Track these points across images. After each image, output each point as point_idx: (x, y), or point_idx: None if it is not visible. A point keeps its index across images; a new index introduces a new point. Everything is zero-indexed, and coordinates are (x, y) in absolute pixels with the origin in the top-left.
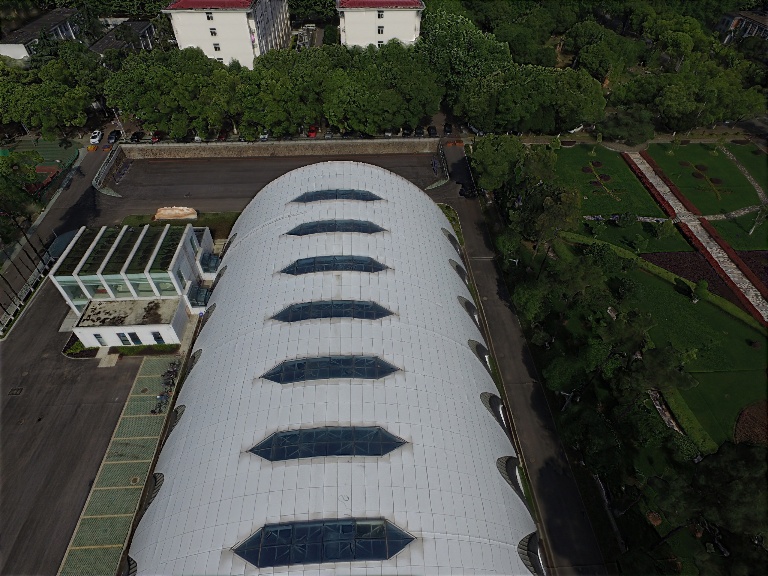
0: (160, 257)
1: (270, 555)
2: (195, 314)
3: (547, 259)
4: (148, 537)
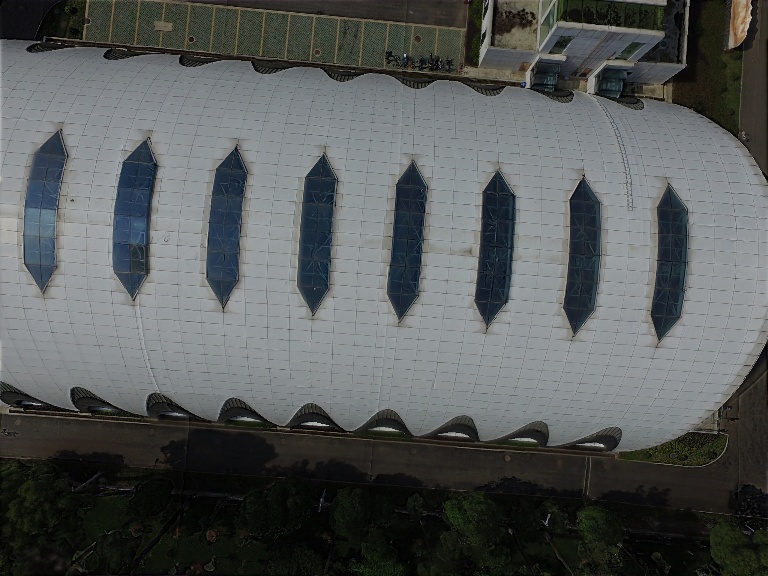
0: (591, 5)
1: (133, 171)
2: (526, 77)
3: (567, 574)
4: (213, 70)
